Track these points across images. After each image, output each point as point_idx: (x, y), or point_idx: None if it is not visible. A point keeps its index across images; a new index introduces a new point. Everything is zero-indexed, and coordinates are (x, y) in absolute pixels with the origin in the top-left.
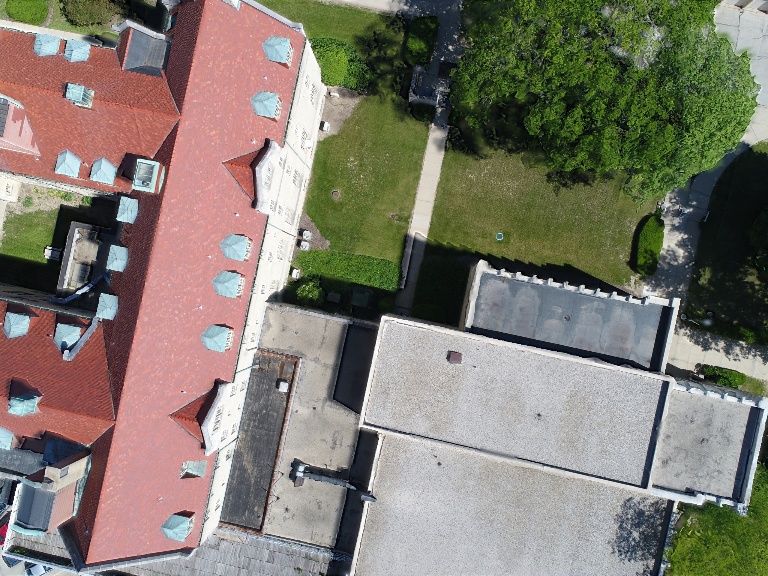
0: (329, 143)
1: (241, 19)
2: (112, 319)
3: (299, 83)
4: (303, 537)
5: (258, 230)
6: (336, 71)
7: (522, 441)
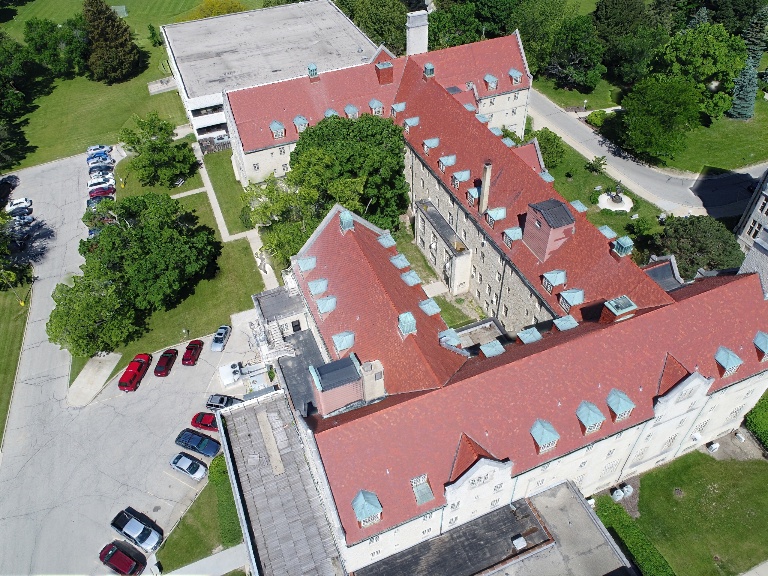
0: (705, 459)
1: (761, 305)
2: (488, 357)
3: (750, 382)
4: None
5: (640, 416)
6: (766, 418)
7: None
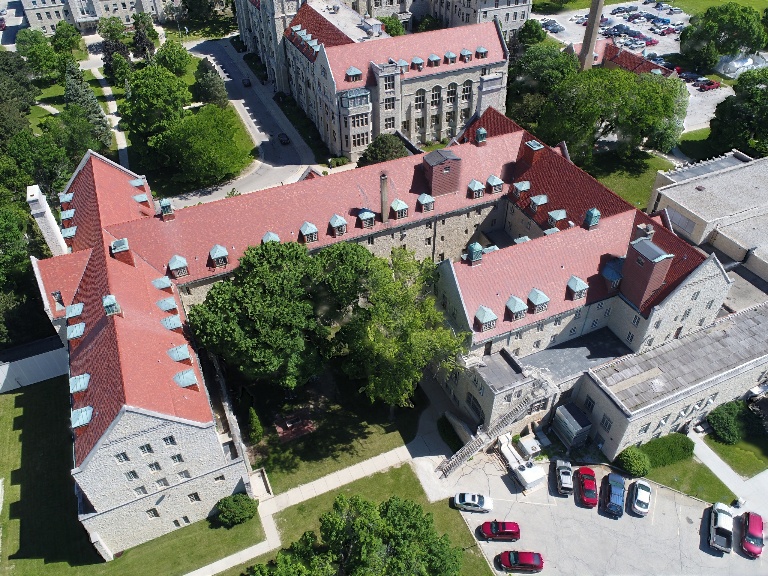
0: None
1: None
2: (566, 217)
3: None
4: (753, 304)
5: None
6: None
7: (766, 196)
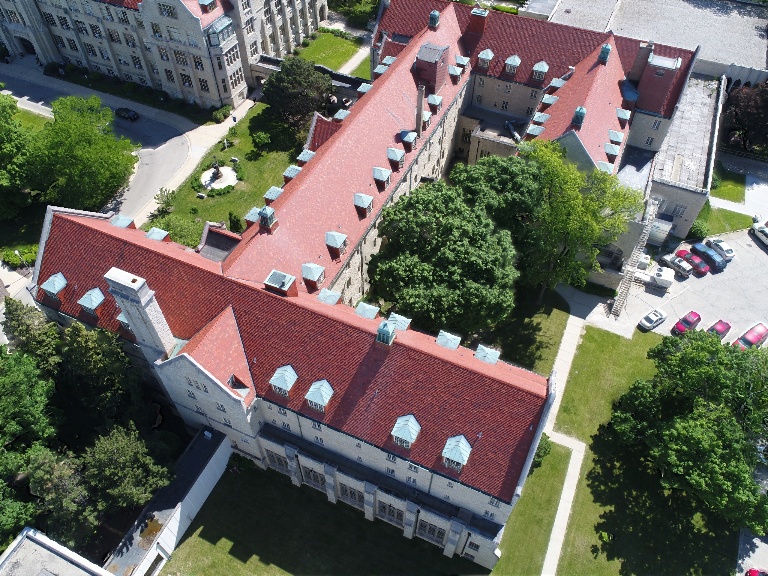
0: None
1: None
2: (549, 67)
3: None
4: None
5: None
6: None
7: (608, 1)
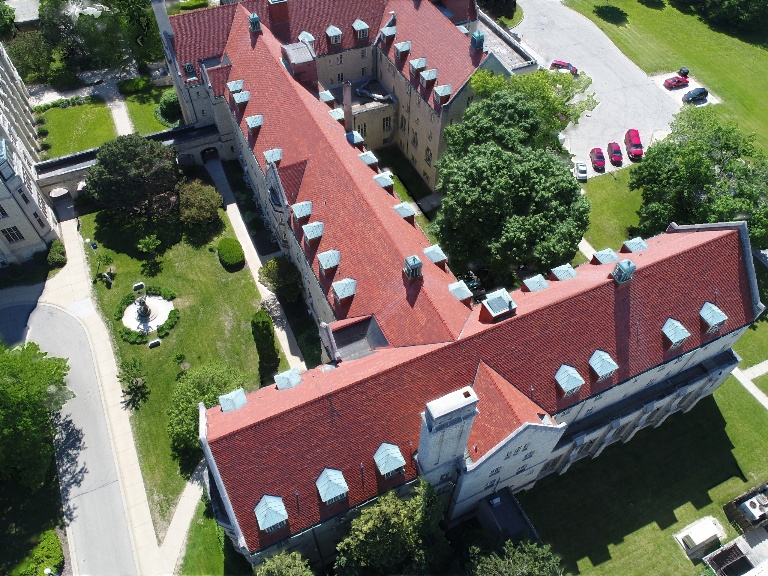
0: None
1: None
2: None
3: None
4: None
5: None
6: None
7: None
